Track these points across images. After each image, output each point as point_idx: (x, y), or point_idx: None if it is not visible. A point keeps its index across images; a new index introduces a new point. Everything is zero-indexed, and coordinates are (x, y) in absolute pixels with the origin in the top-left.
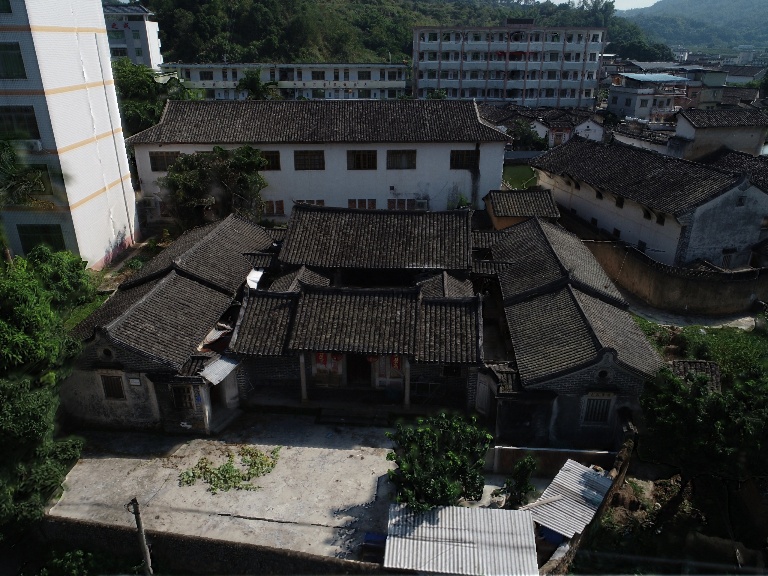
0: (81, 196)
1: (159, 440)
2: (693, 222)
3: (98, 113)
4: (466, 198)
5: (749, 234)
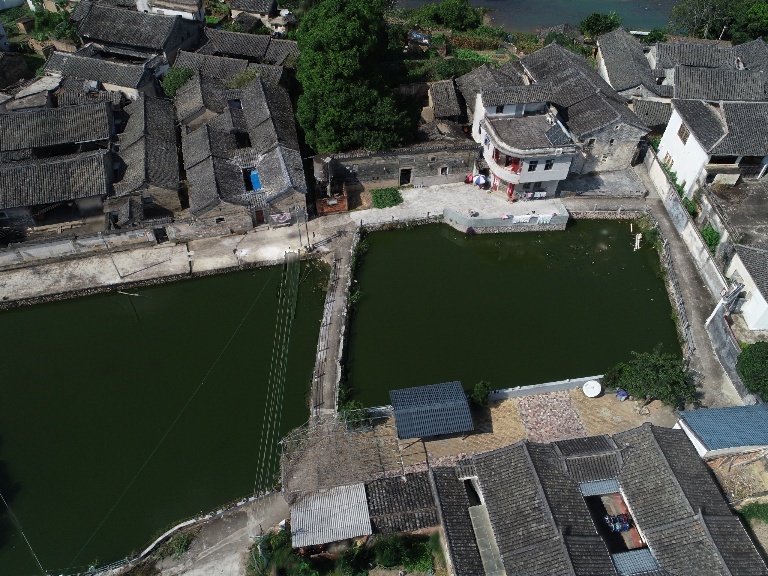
0: None
1: None
2: None
3: None
4: None
5: None
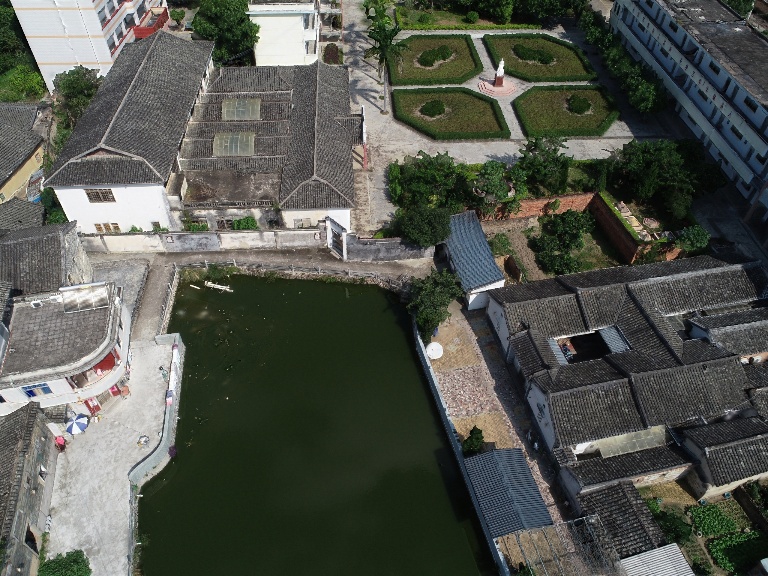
0: (49, 61)
1: None
2: None
3: (72, 24)
4: None
5: None
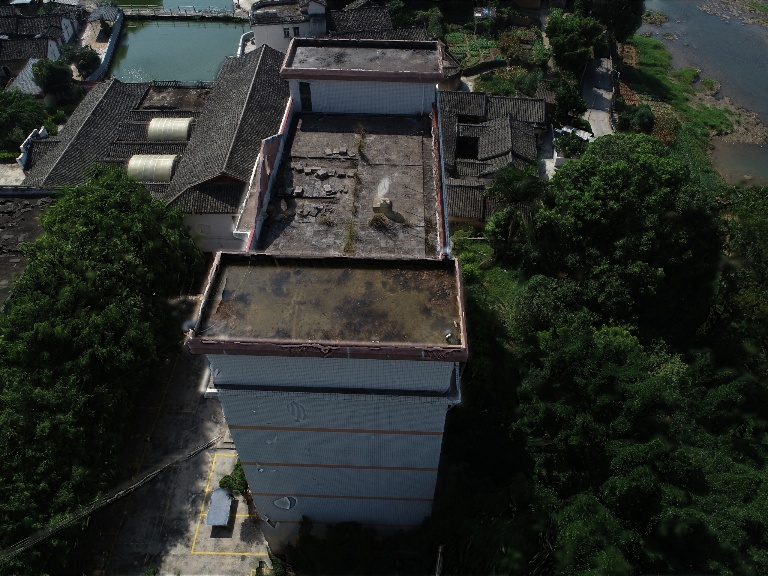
0: None
1: None
2: None
3: None
4: None
5: None
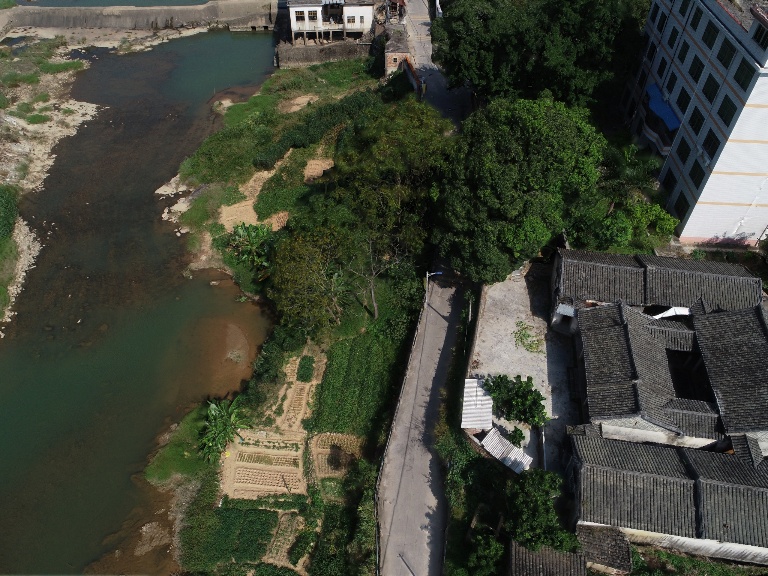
0: (716, 200)
1: (544, 310)
2: None
3: None
4: None
5: None
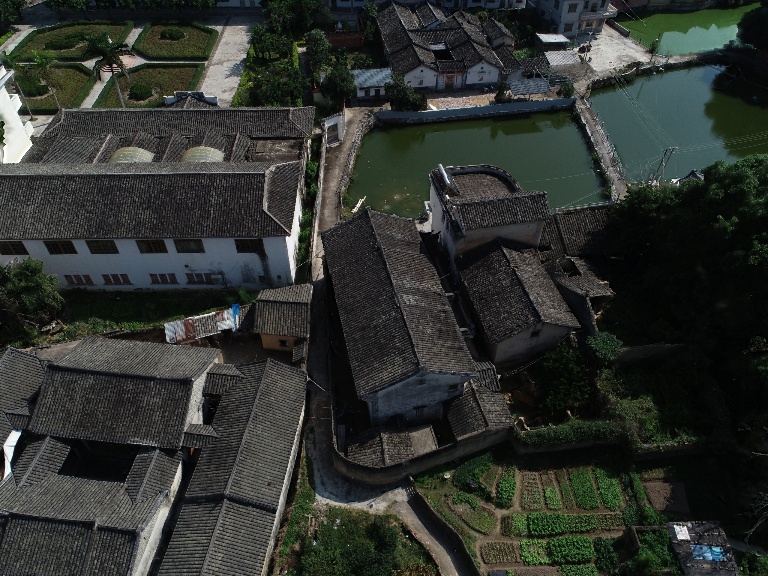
0: None
1: None
2: (378, 399)
3: None
4: (259, 272)
5: (437, 396)
